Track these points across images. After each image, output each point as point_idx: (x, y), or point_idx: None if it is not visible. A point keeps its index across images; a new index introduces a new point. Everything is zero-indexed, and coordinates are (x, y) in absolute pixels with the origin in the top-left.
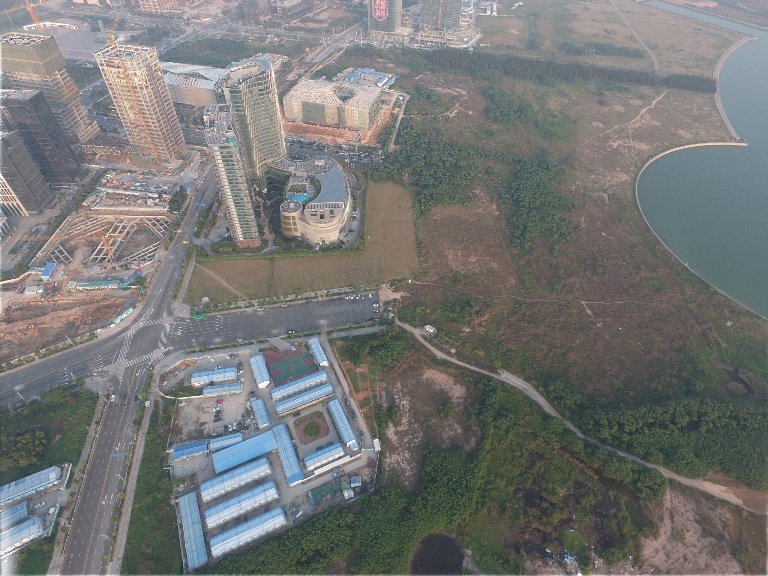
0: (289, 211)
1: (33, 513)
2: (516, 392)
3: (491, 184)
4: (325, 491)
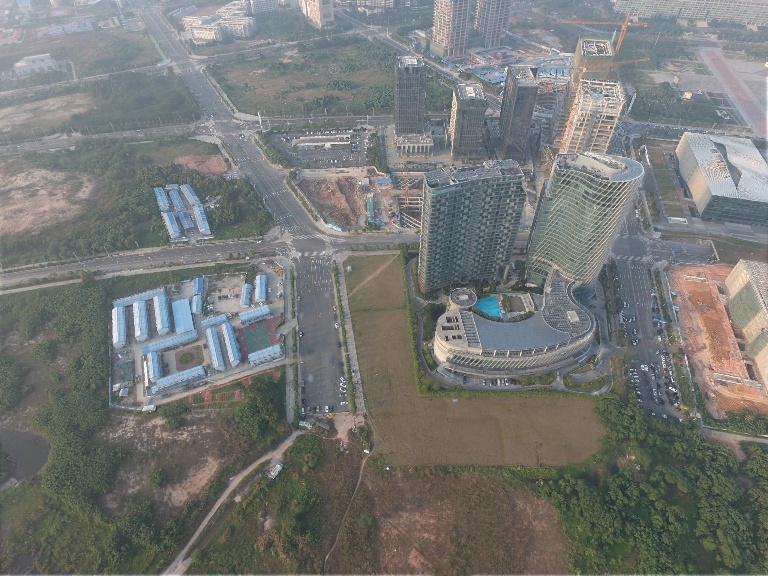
0: (453, 296)
1: (188, 232)
2: (148, 575)
3: None
4: (127, 370)
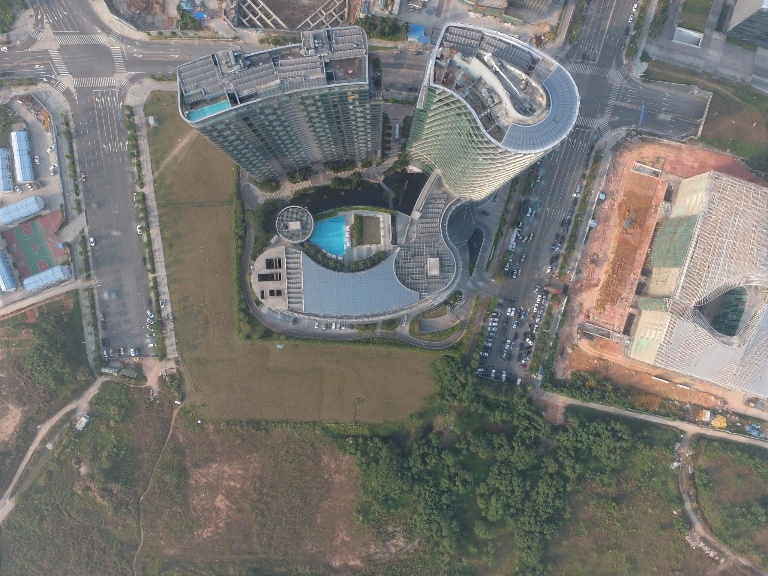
0: (281, 222)
1: None
2: None
3: (419, 572)
4: None
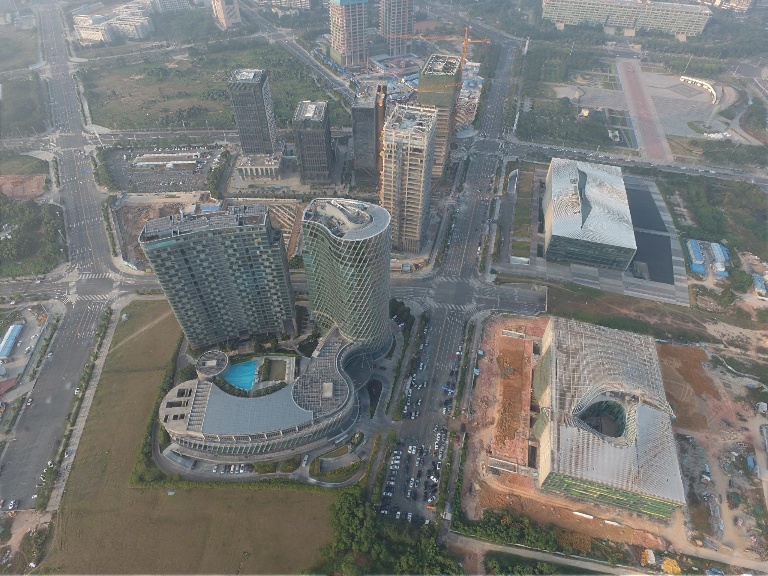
0: (201, 362)
1: None
2: None
3: None
4: None
